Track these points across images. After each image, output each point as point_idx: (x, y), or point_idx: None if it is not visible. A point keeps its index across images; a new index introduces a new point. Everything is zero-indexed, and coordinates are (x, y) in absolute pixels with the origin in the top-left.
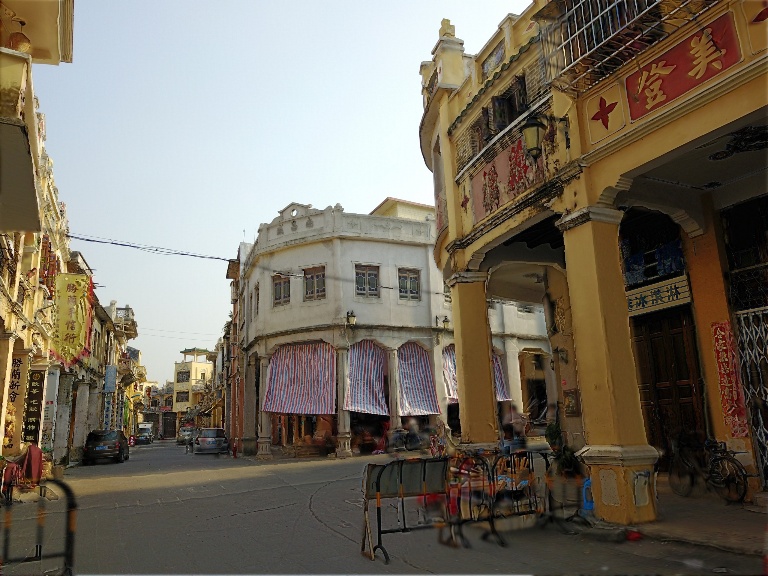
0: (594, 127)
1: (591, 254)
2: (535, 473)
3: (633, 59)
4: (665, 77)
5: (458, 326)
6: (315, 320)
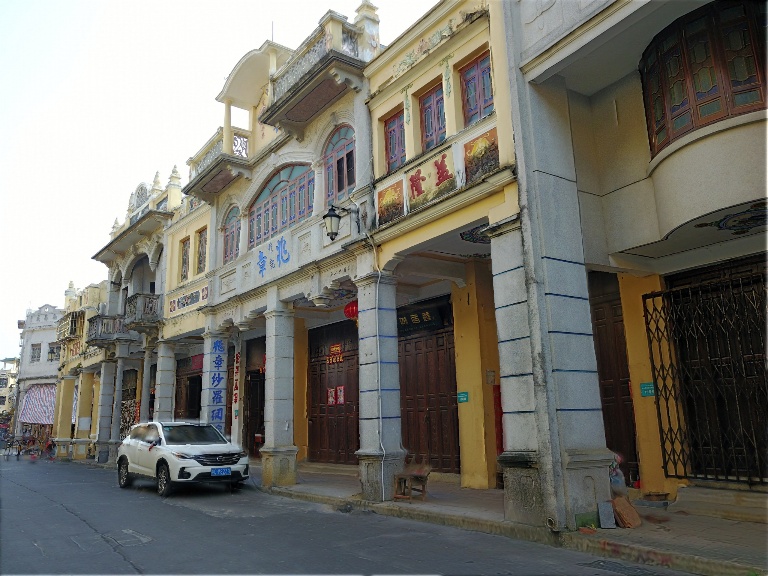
0: (69, 353)
1: (63, 388)
2: (36, 445)
3: None
4: None
5: None
6: (52, 372)
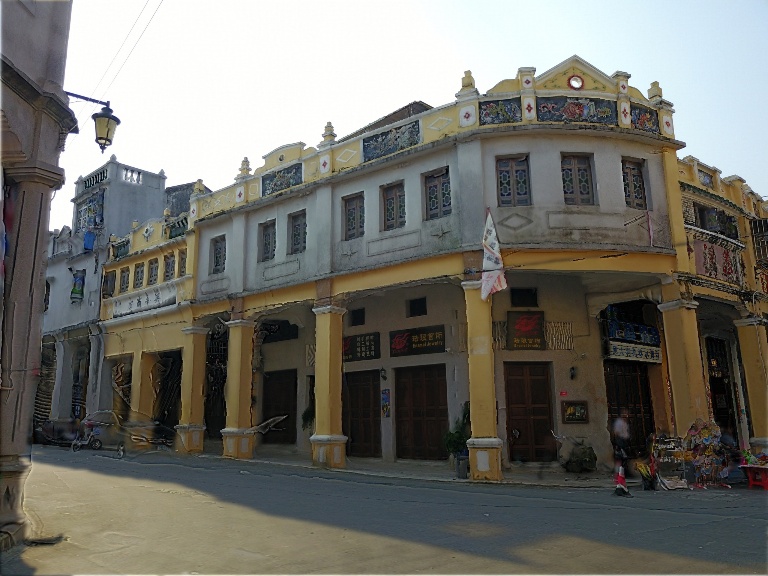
0: None
1: None
2: None
3: (764, 267)
4: (766, 284)
5: (696, 344)
6: None
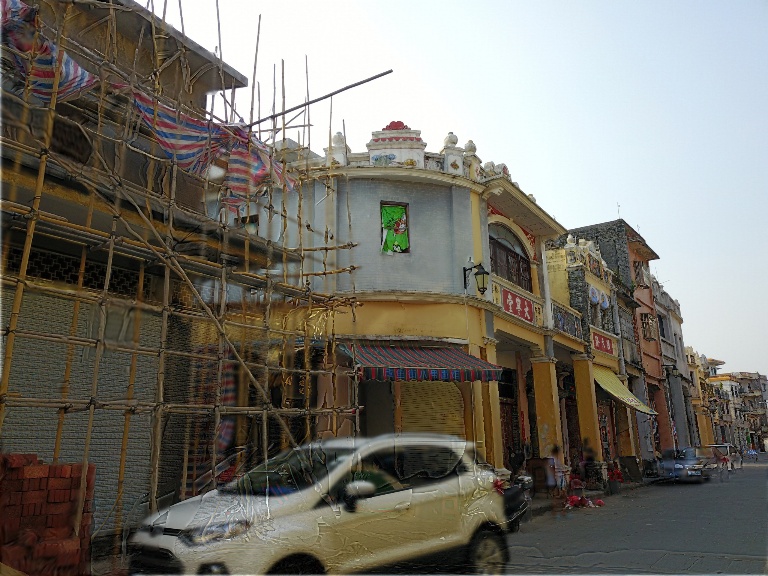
0: None
1: None
2: None
3: None
4: None
5: None
6: None
